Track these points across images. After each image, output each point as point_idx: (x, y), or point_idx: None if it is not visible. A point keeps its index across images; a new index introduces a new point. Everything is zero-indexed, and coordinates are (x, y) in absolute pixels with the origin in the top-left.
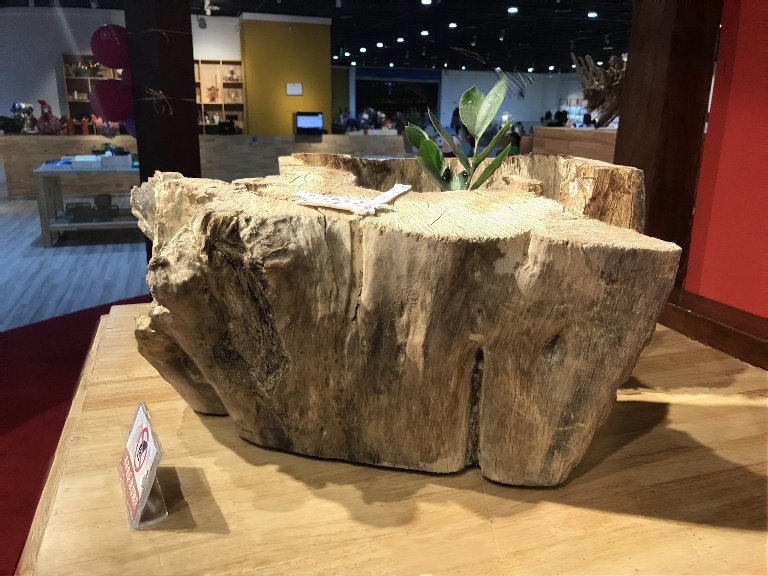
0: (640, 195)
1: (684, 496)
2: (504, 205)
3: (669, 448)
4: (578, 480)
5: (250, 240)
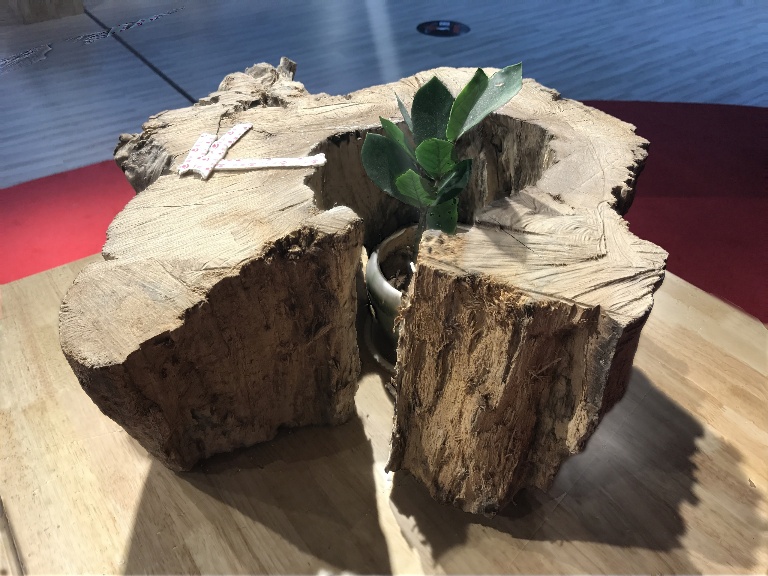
0: (599, 358)
1: (169, 574)
2: (228, 229)
3: (264, 567)
4: (186, 484)
5: (133, 151)
